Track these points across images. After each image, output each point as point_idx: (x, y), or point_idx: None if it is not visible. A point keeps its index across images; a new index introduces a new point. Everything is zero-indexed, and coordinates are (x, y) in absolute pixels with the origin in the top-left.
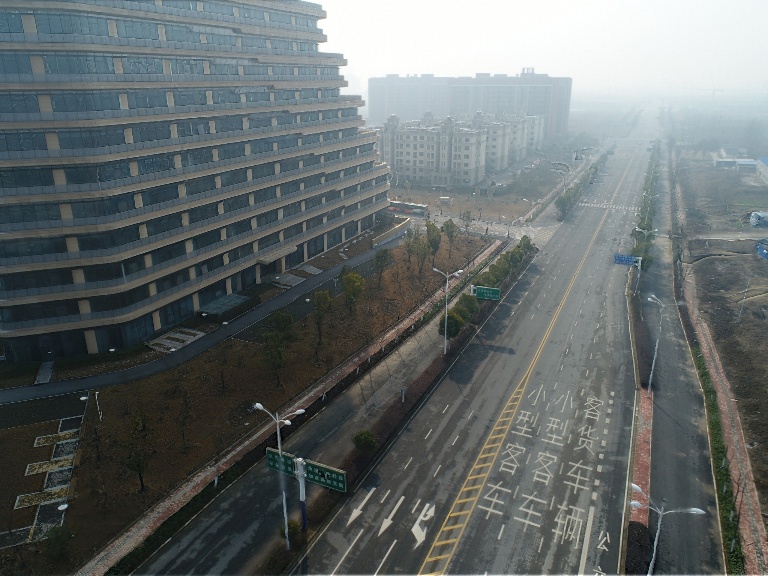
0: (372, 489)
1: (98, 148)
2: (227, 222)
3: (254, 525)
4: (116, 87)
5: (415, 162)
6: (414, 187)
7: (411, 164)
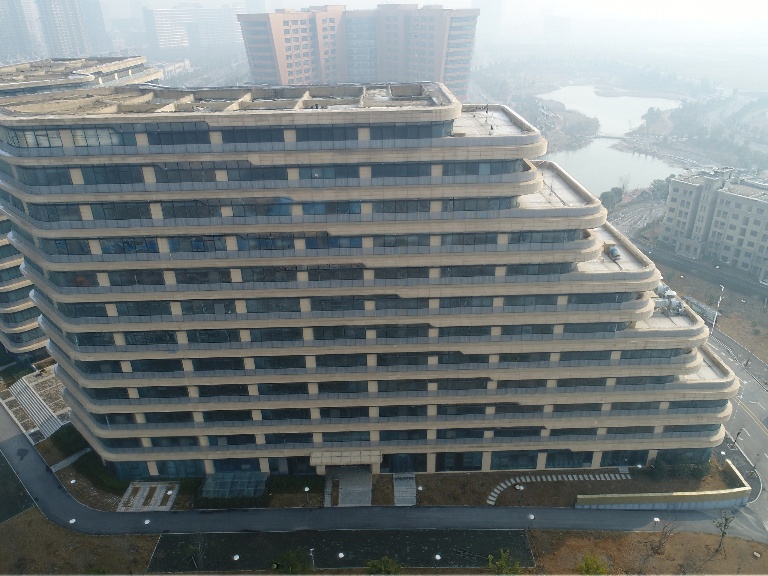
0: None
1: (74, 318)
2: (256, 406)
3: None
4: (84, 269)
5: None
6: None
7: None
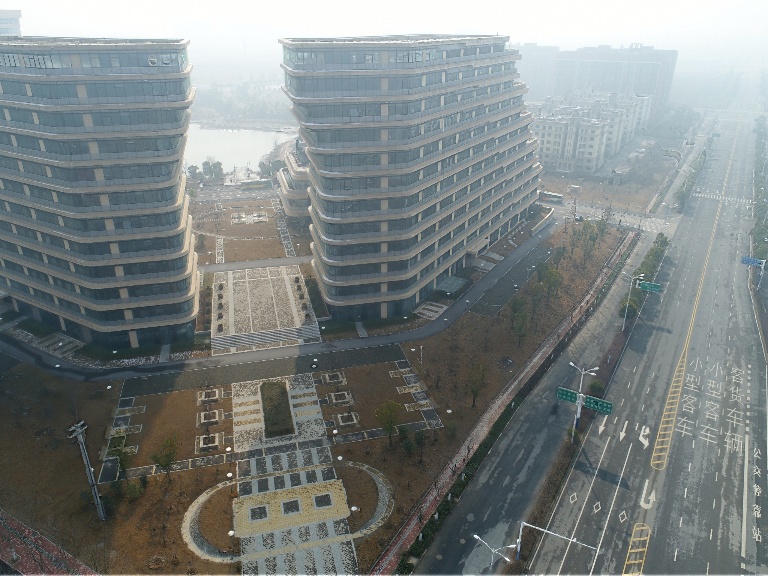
0: (606, 415)
1: (409, 185)
2: (456, 225)
3: (545, 430)
4: (422, 145)
5: (542, 149)
6: None
7: (538, 150)
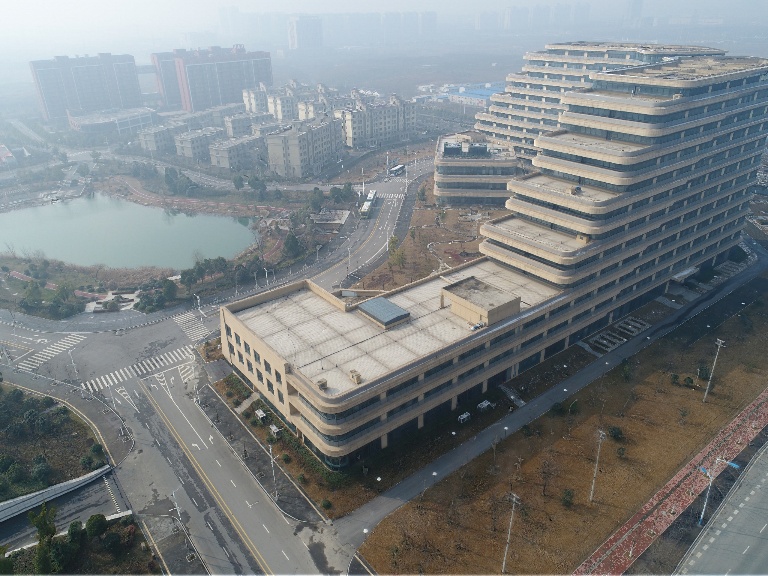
0: None
1: None
2: None
3: None
4: None
5: (386, 128)
6: (409, 144)
7: (383, 130)
